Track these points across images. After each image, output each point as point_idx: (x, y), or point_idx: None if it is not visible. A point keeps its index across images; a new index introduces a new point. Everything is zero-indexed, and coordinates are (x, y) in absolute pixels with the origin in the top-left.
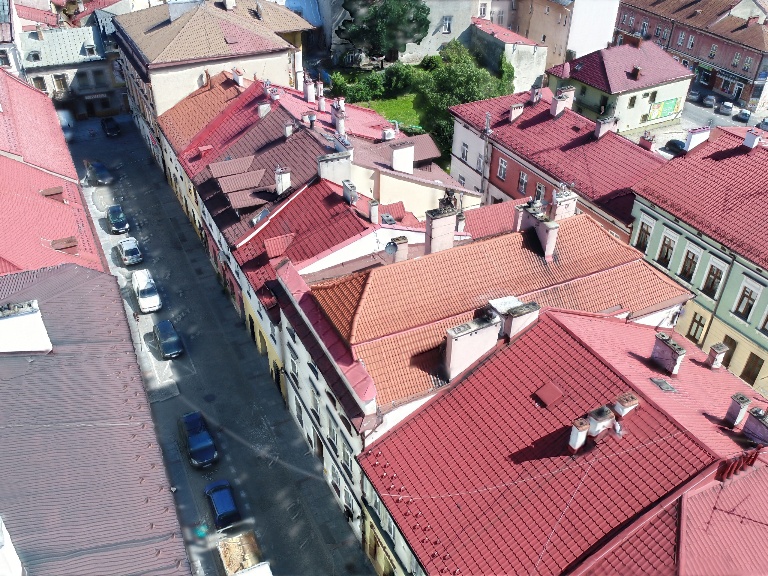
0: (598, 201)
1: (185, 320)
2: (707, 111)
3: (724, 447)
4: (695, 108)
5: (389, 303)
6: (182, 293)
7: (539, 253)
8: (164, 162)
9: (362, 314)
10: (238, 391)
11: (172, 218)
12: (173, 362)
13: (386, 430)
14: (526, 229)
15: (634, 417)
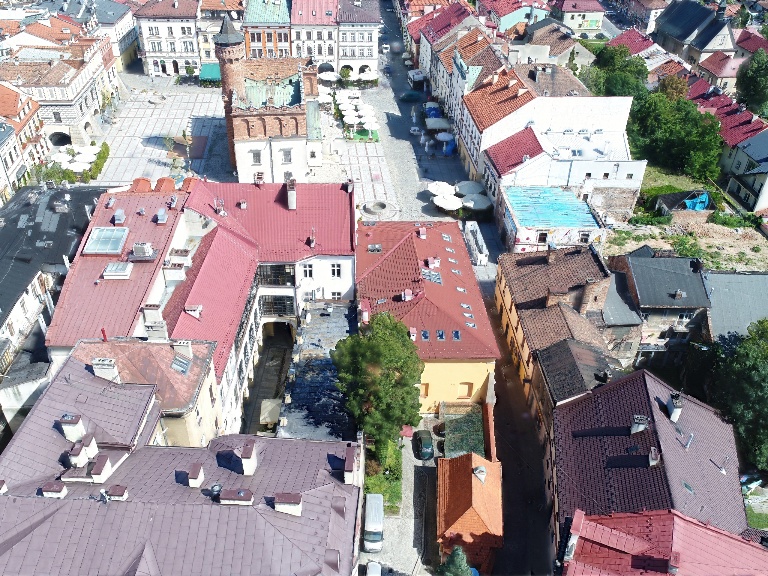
0: None
1: (388, 30)
2: (620, 31)
3: None
4: (616, 29)
5: (418, 2)
6: (390, 27)
7: (449, 1)
8: (395, 4)
9: (413, 2)
10: (395, 38)
11: (393, 17)
12: (383, 34)
13: (412, 21)
14: None
15: None
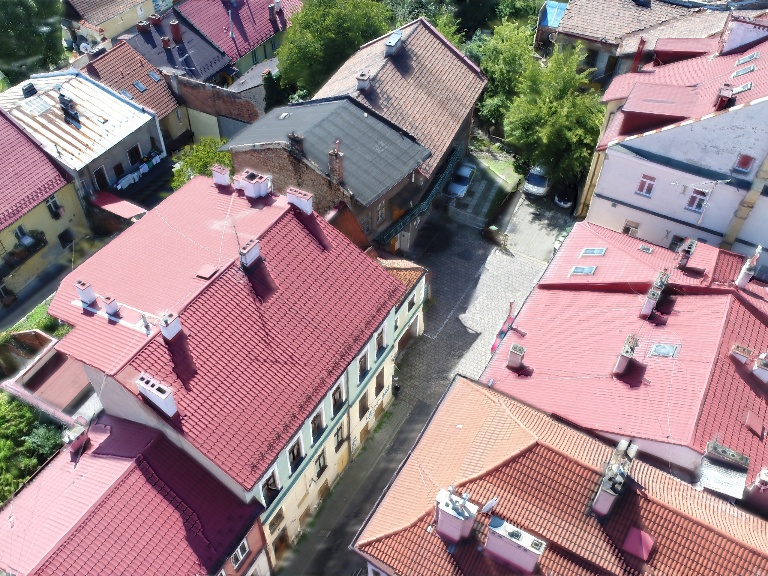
0: (212, 567)
1: None
2: None
3: (702, 302)
4: None
5: None
6: None
7: None
8: None
9: None
10: None
11: None
12: None
13: None
14: (617, 497)
15: None
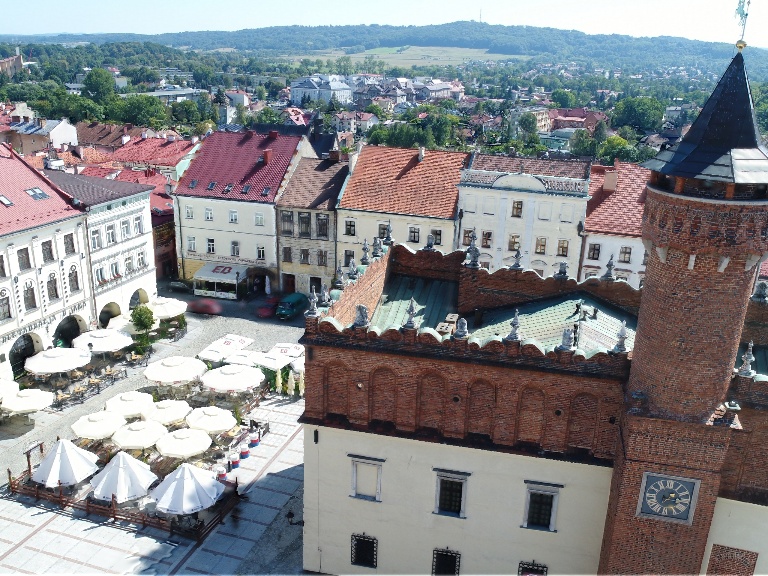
0: None
1: None
2: None
3: None
4: None
5: None
6: None
7: (79, 157)
8: None
9: None
10: None
11: None
12: None
13: None
14: None
15: (122, 174)
